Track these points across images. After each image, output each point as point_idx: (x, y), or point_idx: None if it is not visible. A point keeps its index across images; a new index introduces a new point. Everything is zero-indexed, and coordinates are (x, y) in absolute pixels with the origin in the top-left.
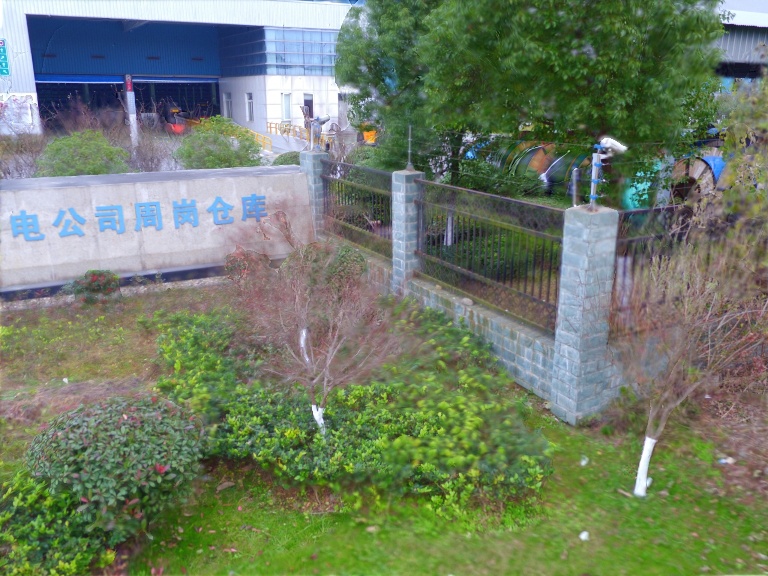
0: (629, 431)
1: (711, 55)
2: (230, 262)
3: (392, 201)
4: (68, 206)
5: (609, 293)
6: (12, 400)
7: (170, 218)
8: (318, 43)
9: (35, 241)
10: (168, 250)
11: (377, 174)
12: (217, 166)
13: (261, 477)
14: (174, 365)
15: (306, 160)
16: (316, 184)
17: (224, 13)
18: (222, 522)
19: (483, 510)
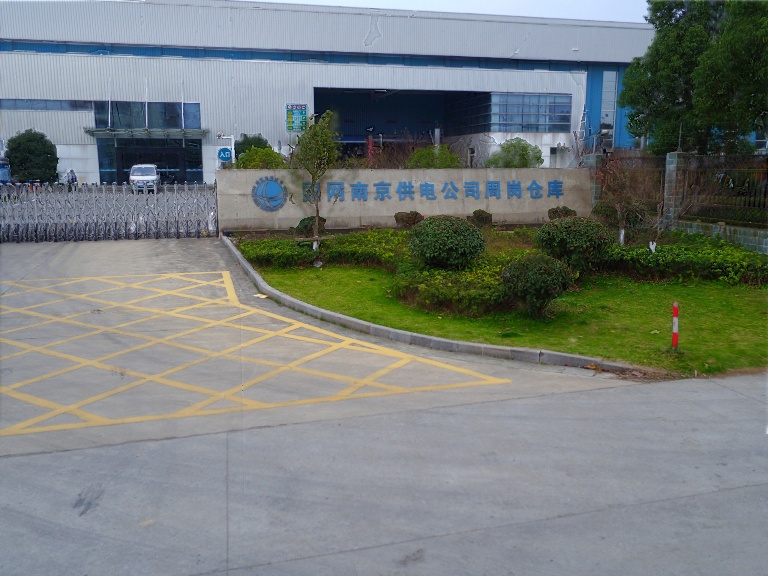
0: None
1: None
2: (553, 212)
3: (666, 171)
4: (450, 180)
5: None
6: None
7: (505, 192)
8: (536, 105)
9: (431, 200)
10: (503, 212)
11: (652, 159)
12: None
13: (624, 273)
14: None
15: (590, 159)
16: None
17: (460, 82)
18: None
19: (749, 284)
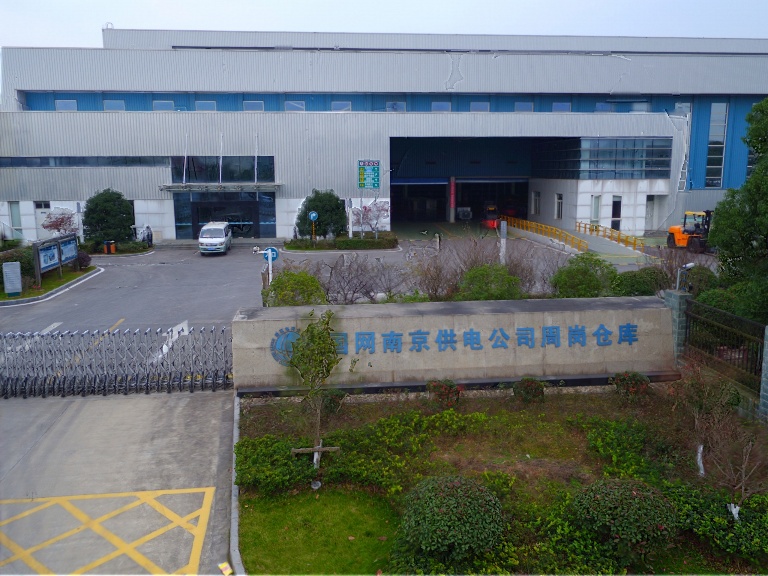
0: None
1: None
2: (620, 380)
3: (764, 348)
4: (499, 327)
5: None
6: (504, 465)
7: (566, 339)
8: (631, 149)
9: (477, 350)
10: (562, 362)
11: (747, 322)
12: (588, 293)
13: (694, 545)
14: (612, 458)
15: (672, 298)
16: (680, 318)
17: (546, 127)
18: (676, 568)
19: None
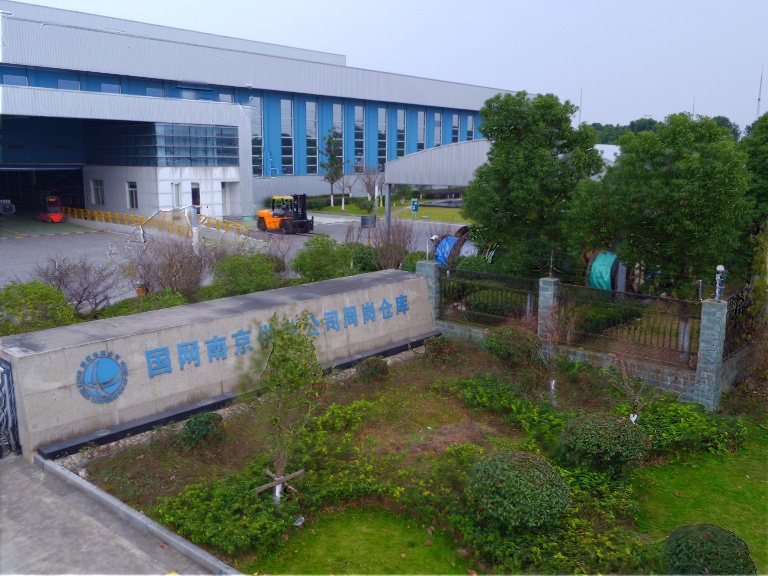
0: (741, 412)
1: (746, 222)
2: (433, 344)
3: (539, 297)
4: None
5: (723, 343)
6: None
7: (361, 317)
8: (203, 137)
9: None
10: (361, 340)
11: (514, 279)
12: (337, 273)
13: None
14: (512, 408)
15: (426, 268)
16: (435, 284)
17: (118, 110)
18: None
19: None
